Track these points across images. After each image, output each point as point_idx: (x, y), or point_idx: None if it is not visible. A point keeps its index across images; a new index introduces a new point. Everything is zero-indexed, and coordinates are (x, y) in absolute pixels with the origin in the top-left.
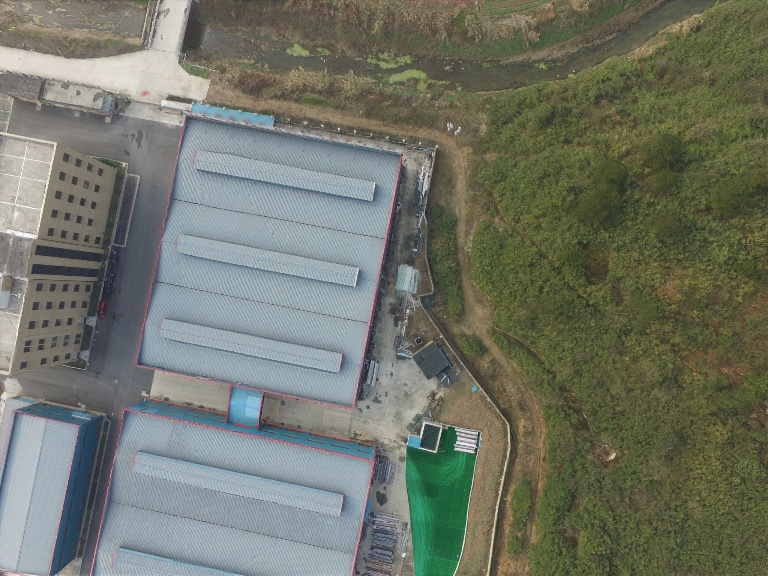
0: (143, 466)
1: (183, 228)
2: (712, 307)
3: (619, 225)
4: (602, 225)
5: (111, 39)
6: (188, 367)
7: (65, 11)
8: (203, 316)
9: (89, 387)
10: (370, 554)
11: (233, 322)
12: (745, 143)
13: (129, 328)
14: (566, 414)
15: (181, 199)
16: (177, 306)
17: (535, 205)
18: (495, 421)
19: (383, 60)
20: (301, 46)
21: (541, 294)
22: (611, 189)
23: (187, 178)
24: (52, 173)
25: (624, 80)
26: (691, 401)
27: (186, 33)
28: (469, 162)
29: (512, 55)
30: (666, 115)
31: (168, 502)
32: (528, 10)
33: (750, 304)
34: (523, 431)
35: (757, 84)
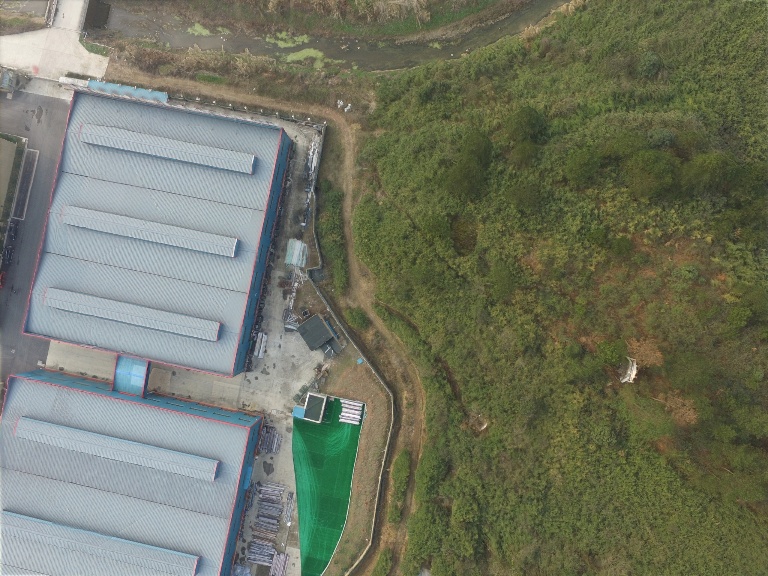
0: (25, 430)
1: (70, 200)
2: (568, 276)
3: (484, 197)
4: (468, 197)
5: (18, 18)
6: (74, 335)
7: None
8: (88, 286)
9: None
10: (256, 523)
11: (117, 292)
12: (606, 116)
13: (26, 299)
14: (441, 385)
15: (70, 171)
16: (64, 276)
17: (411, 178)
18: (379, 393)
19: (281, 39)
20: (202, 25)
21: (414, 265)
22: (471, 160)
23: (75, 151)
24: None
25: (510, 58)
26: (551, 370)
27: (88, 12)
28: (357, 138)
29: (407, 35)
30: (539, 90)
31: (51, 467)
32: None
33: (604, 273)
34: (405, 403)
35: (620, 58)
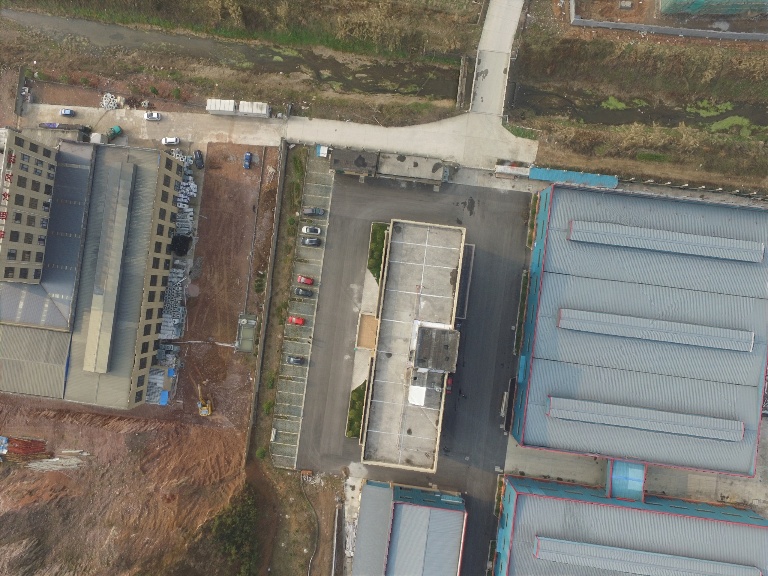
0: (548, 552)
1: (557, 301)
2: None
3: None
4: None
5: (418, 103)
6: (572, 444)
7: (366, 76)
8: (585, 391)
9: (439, 466)
10: None
11: (618, 395)
12: None
13: (477, 403)
14: None
15: (550, 271)
16: (557, 382)
17: None
18: None
19: (703, 108)
20: (616, 99)
21: None
22: None
23: (556, 249)
24: None
25: None
26: None
27: None
28: None
29: None
30: None
31: None
32: None
33: None
34: None
35: None
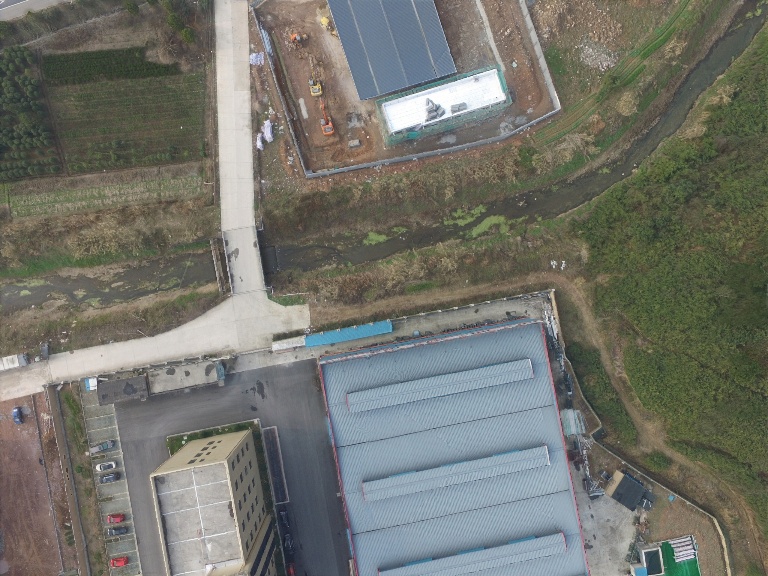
0: None
1: (359, 473)
2: None
3: None
4: (755, 325)
5: (183, 295)
6: None
7: (122, 284)
8: (412, 550)
9: None
10: None
11: (444, 543)
12: None
13: None
14: None
15: (344, 445)
16: (383, 551)
17: (677, 321)
18: (702, 520)
19: (459, 218)
20: (376, 233)
21: (717, 402)
22: (762, 298)
23: (343, 422)
24: (233, 492)
25: (692, 165)
26: None
27: (262, 265)
28: (586, 292)
29: (575, 170)
30: (759, 197)
31: None
32: (579, 127)
33: None
34: (730, 520)
35: None
